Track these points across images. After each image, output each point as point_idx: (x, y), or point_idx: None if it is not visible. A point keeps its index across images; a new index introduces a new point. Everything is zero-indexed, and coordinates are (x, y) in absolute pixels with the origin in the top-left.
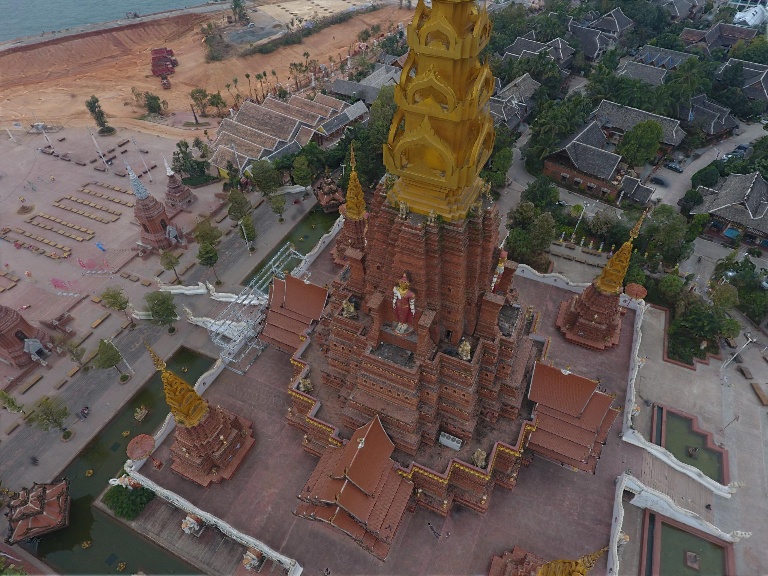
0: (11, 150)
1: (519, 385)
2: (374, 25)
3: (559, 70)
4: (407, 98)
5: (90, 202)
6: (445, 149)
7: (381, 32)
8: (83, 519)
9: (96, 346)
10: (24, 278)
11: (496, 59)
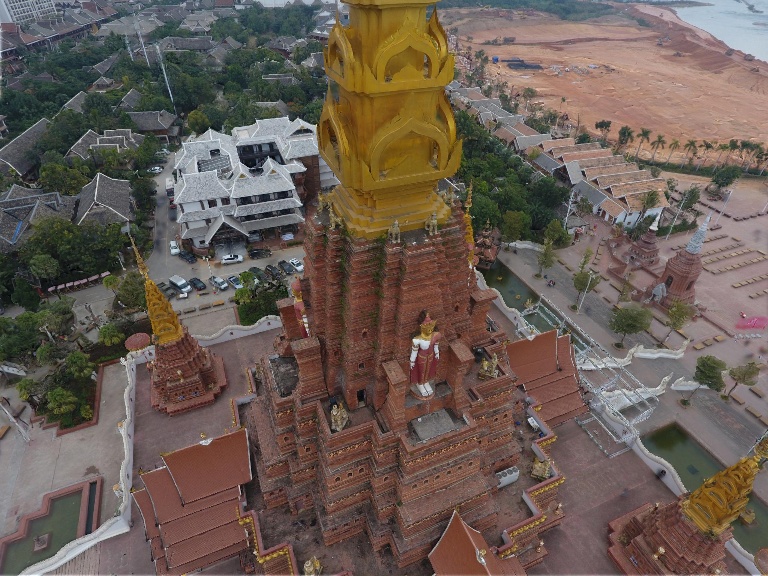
0: None
1: (252, 401)
2: None
3: None
4: None
5: None
6: None
7: None
8: None
9: None
10: None
11: None
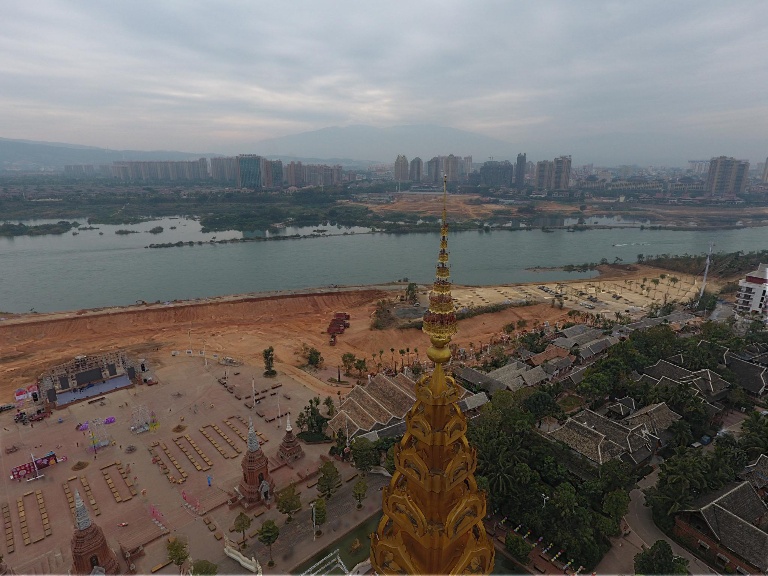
0: (200, 375)
1: None
2: (520, 320)
3: (704, 406)
4: (388, 504)
5: (225, 434)
6: (415, 570)
7: (526, 327)
8: None
9: None
10: (140, 494)
11: (630, 380)
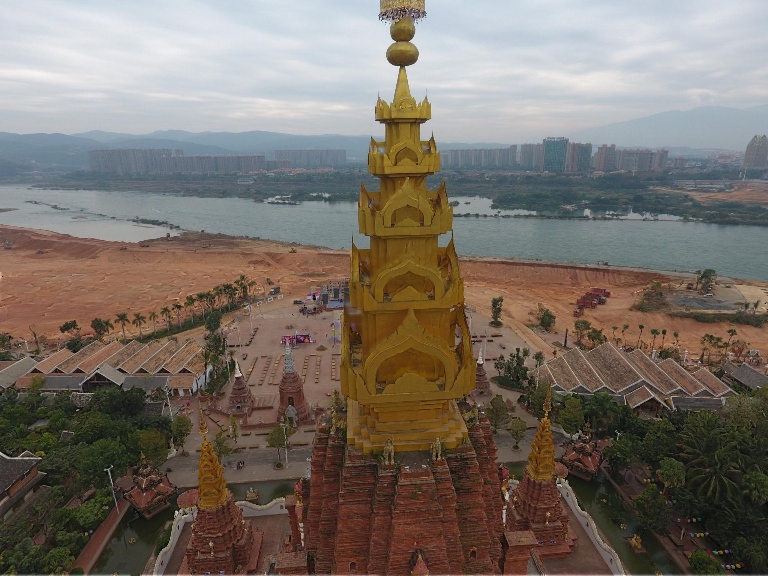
0: None
1: None
2: None
3: None
4: None
5: None
6: (345, 337)
7: None
8: (155, 525)
9: (311, 439)
10: None
11: None
